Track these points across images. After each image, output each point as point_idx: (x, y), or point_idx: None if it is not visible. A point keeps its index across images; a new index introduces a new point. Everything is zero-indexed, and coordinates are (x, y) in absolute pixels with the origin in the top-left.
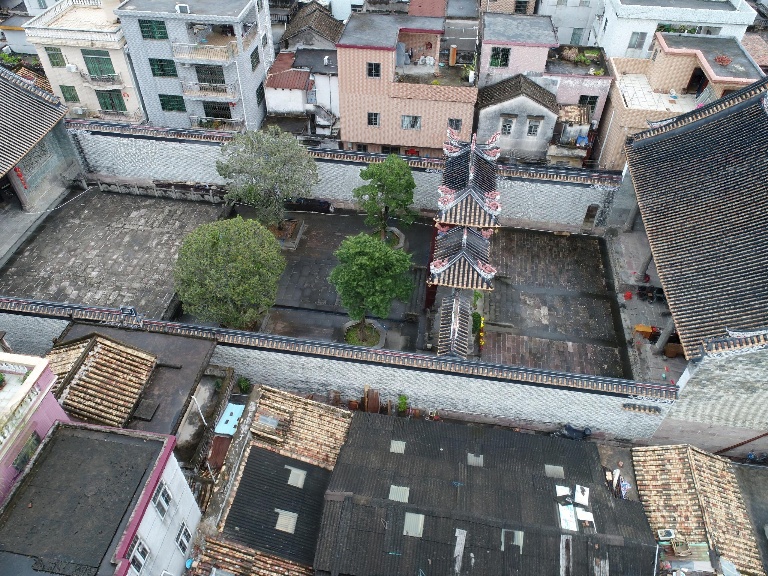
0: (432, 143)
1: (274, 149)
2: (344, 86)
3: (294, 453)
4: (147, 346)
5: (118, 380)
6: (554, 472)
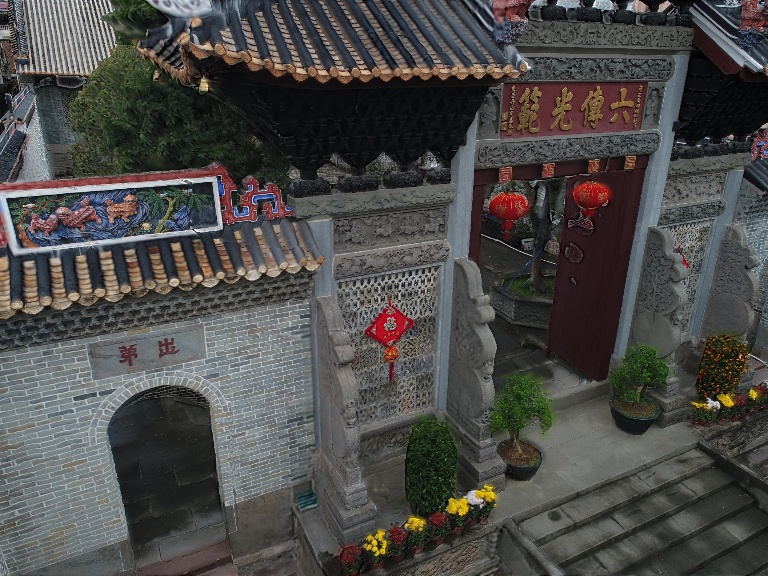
0: None
1: None
2: None
3: None
4: None
5: None
6: None
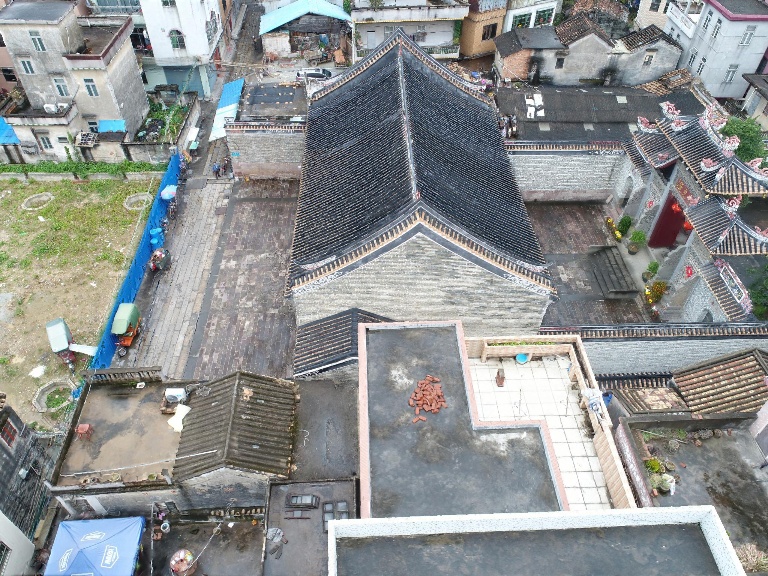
0: None
1: None
2: None
3: None
4: None
5: None
6: (545, 127)
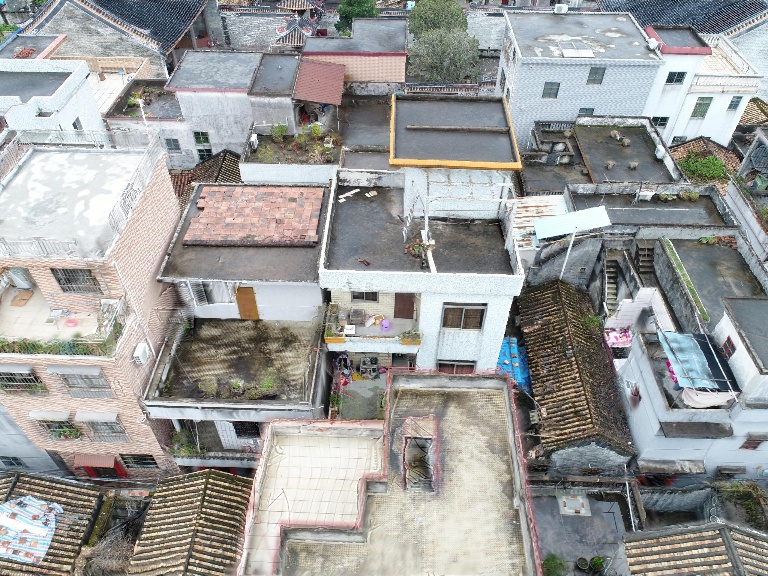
0: None
1: None
2: None
3: (382, 3)
4: None
5: None
6: None
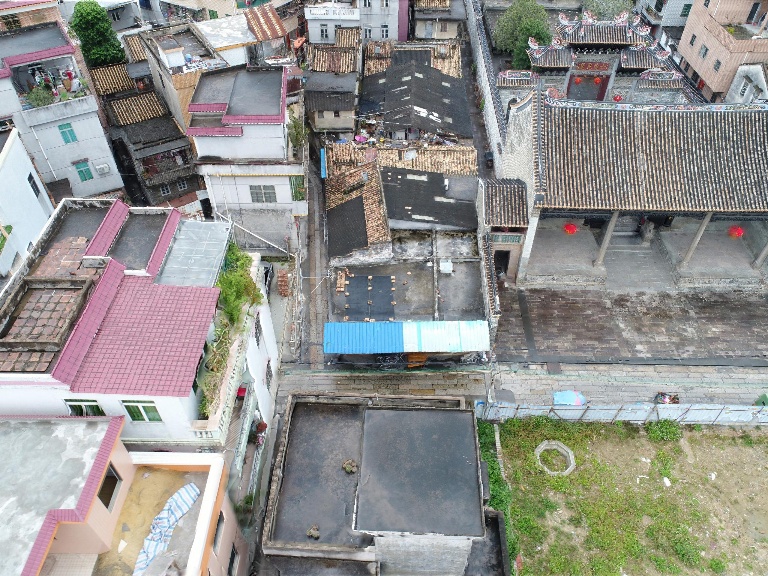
0: (704, 75)
1: (609, 5)
2: (694, 7)
3: (433, 62)
4: (457, 8)
5: (435, 0)
6: (448, 120)
